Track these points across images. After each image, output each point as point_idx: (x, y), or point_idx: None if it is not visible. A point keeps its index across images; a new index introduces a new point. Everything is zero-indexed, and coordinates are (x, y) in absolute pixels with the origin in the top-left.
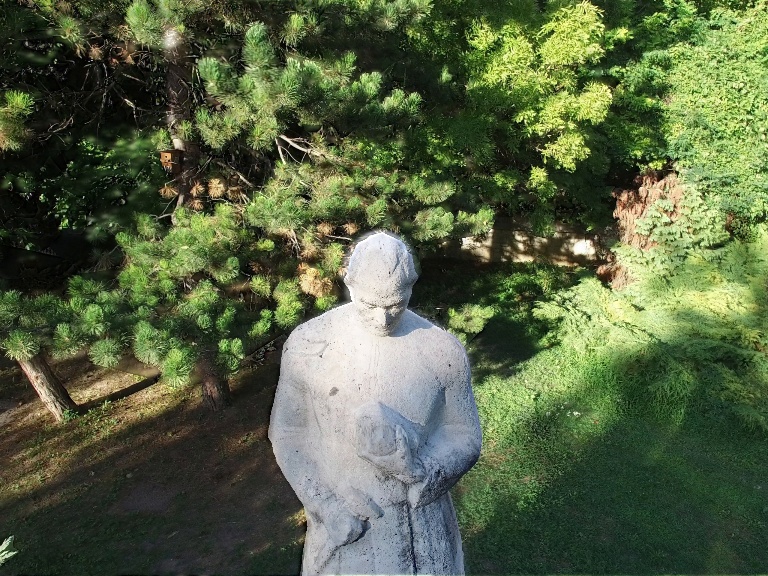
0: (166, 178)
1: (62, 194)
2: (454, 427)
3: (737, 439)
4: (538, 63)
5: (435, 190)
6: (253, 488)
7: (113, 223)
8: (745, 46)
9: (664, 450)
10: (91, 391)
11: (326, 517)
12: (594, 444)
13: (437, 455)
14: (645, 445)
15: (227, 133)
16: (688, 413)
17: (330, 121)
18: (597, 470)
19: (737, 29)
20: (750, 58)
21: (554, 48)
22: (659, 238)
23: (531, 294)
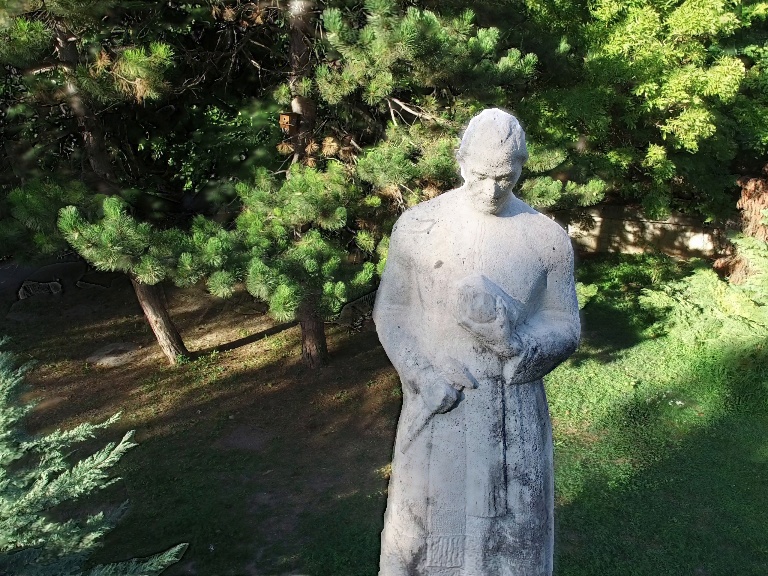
0: (283, 139)
1: (188, 159)
2: (554, 313)
3: None
4: (665, 34)
5: (545, 157)
6: (344, 440)
7: (233, 177)
8: None
9: None
10: (202, 341)
11: (424, 385)
12: (697, 435)
13: (536, 334)
14: (755, 442)
15: (345, 88)
16: None
17: (444, 77)
18: (698, 461)
19: None
20: None
21: (684, 17)
22: None
23: (638, 285)
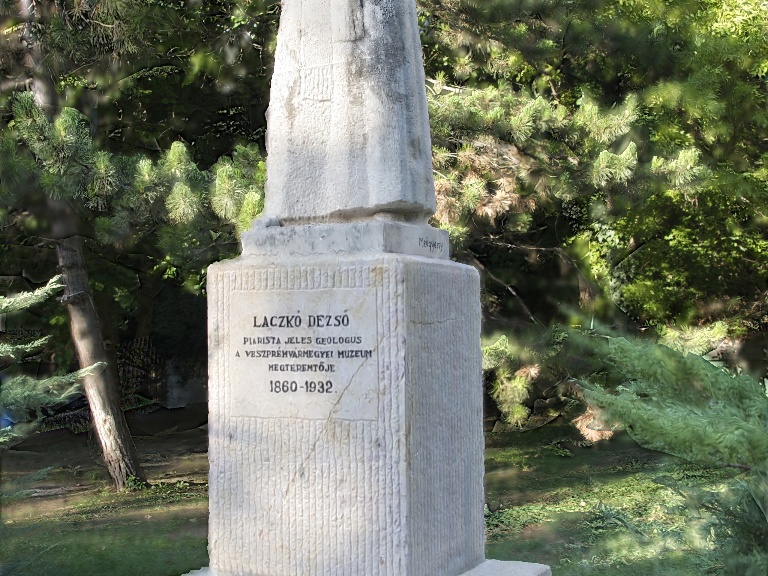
0: None
1: None
2: None
3: None
4: None
5: (614, 121)
6: None
7: None
8: None
9: None
10: (166, 480)
11: None
12: None
13: None
14: None
15: None
16: None
17: None
18: None
19: None
20: None
21: None
22: None
23: None
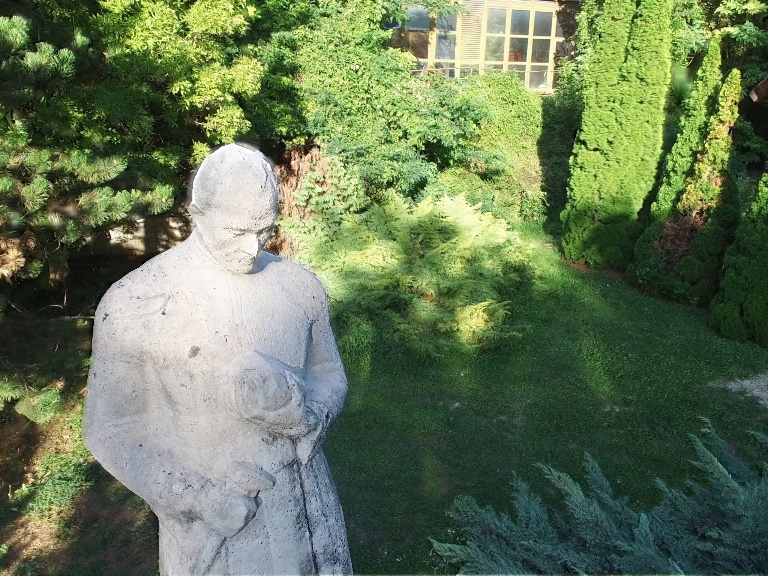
0: None
1: None
2: (322, 367)
3: (415, 370)
4: (184, 31)
5: (101, 166)
6: None
7: None
8: (353, 33)
9: (363, 395)
10: None
11: (208, 509)
12: None
13: (320, 398)
14: None
15: None
16: (373, 358)
17: None
18: None
19: (343, 18)
20: (358, 44)
21: (200, 16)
22: (316, 208)
23: None
